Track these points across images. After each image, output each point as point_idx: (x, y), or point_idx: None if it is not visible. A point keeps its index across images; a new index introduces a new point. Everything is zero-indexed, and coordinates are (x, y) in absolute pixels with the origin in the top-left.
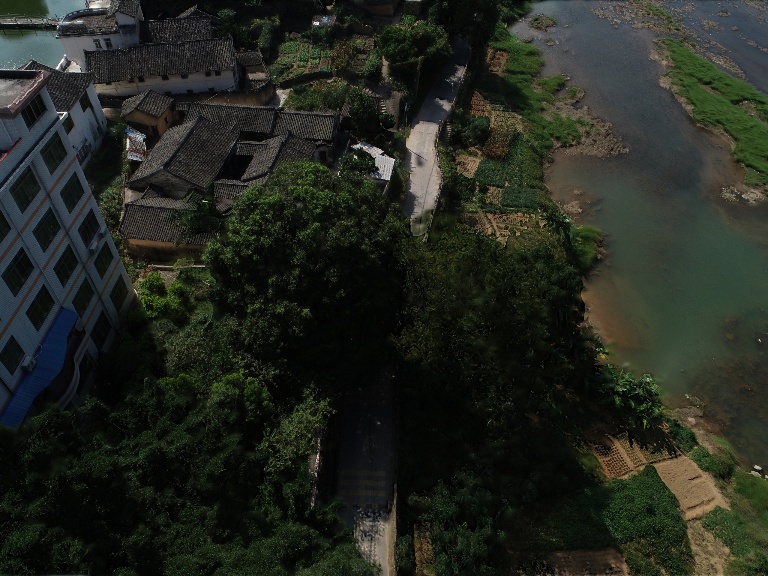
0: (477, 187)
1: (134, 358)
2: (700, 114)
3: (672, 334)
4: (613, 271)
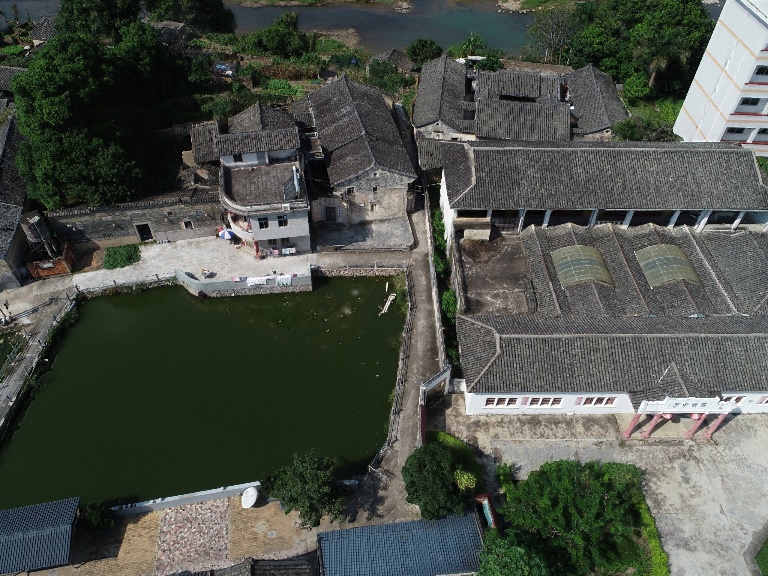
0: None
1: None
2: (308, 1)
3: None
4: None
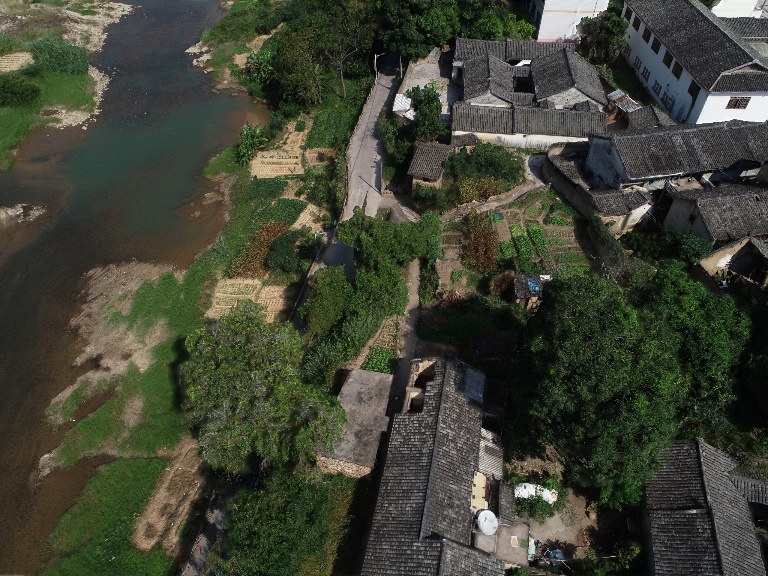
0: (306, 197)
1: (508, 1)
2: None
3: (200, 119)
4: (213, 151)
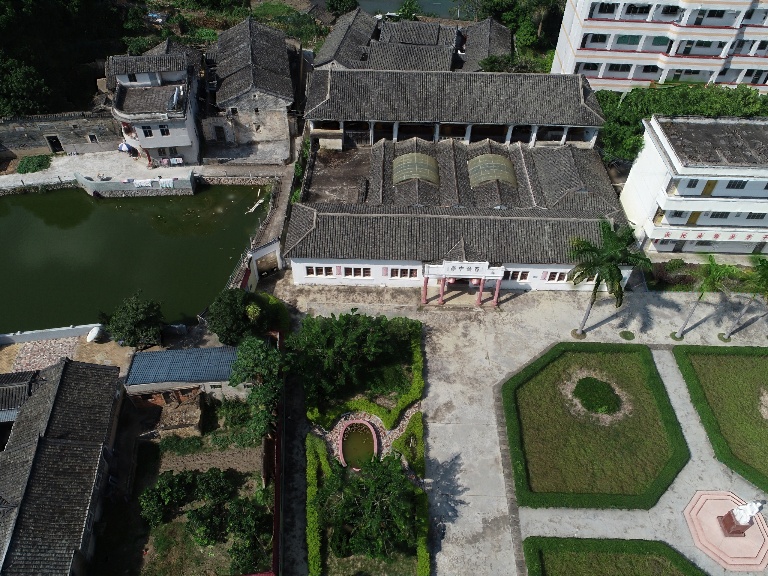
0: None
1: None
2: None
3: None
4: None
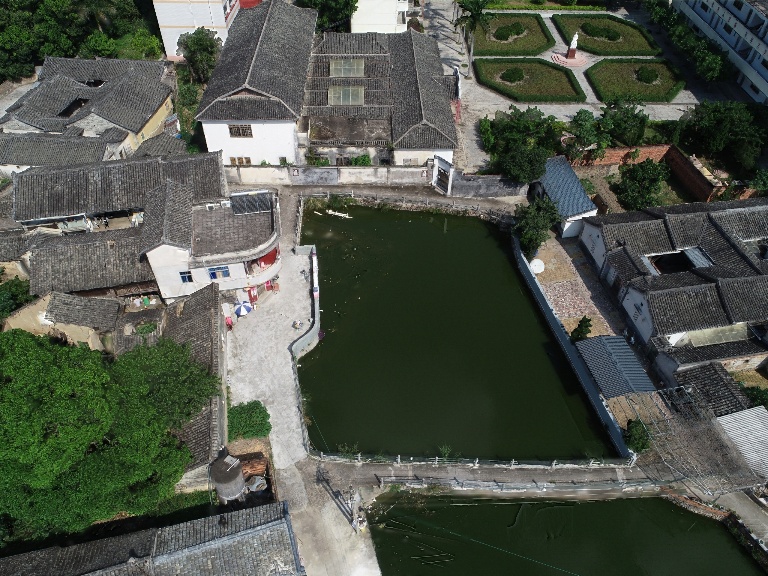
0: None
1: None
2: None
3: None
4: None
